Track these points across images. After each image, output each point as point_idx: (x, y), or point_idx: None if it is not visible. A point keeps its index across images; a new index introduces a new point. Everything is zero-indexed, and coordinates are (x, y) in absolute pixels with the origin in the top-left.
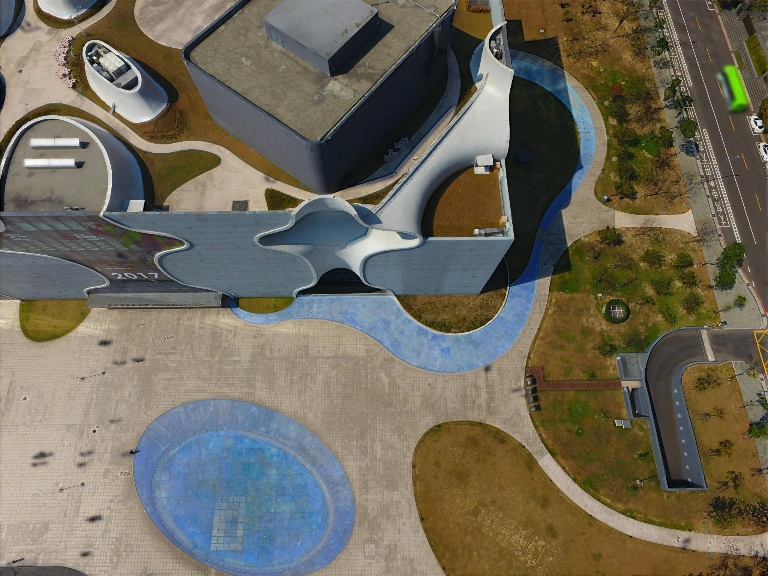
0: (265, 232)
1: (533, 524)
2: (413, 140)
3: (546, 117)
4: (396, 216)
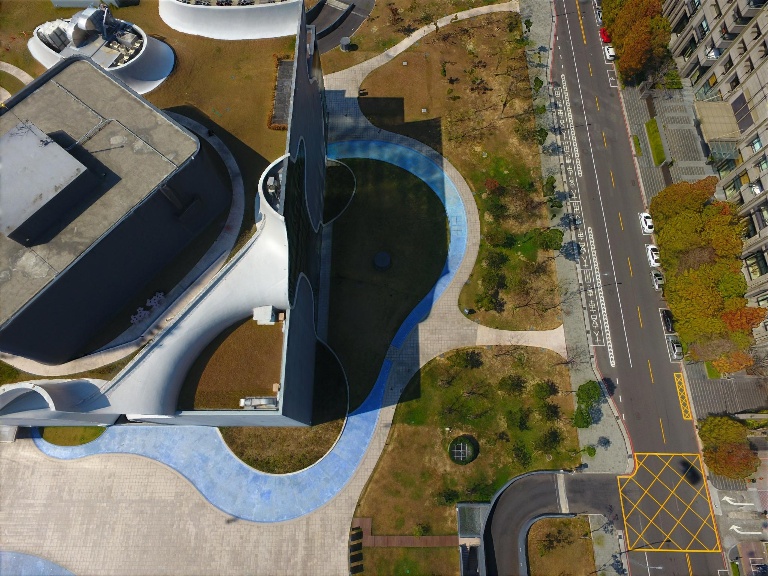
0: None
1: None
2: (171, 295)
3: (416, 212)
4: (131, 394)
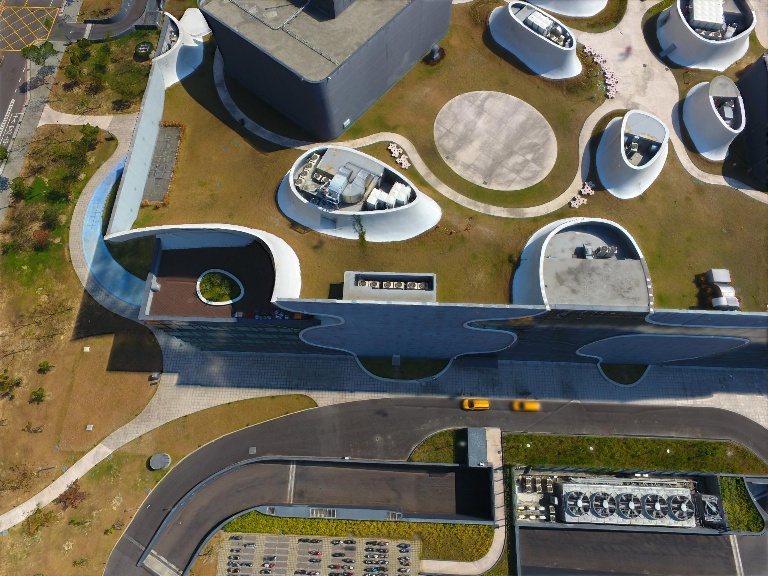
0: None
1: None
2: None
3: None
4: None
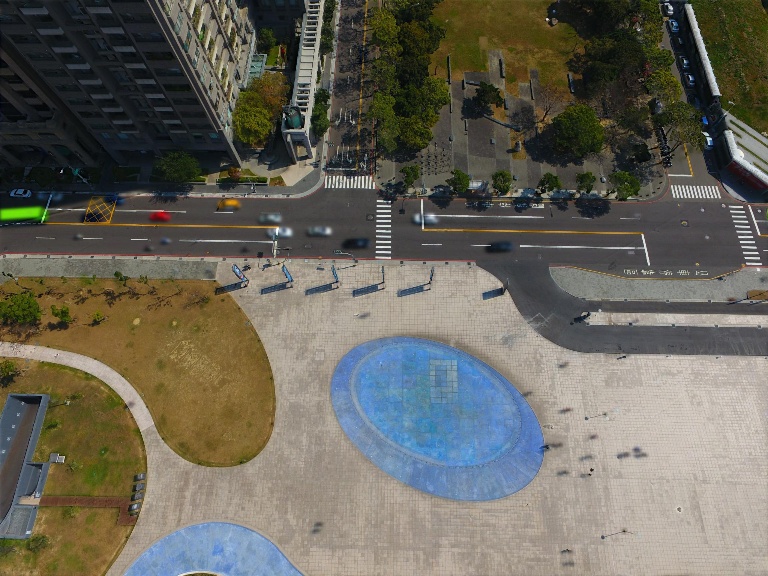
0: None
1: (175, 371)
2: None
3: None
4: None
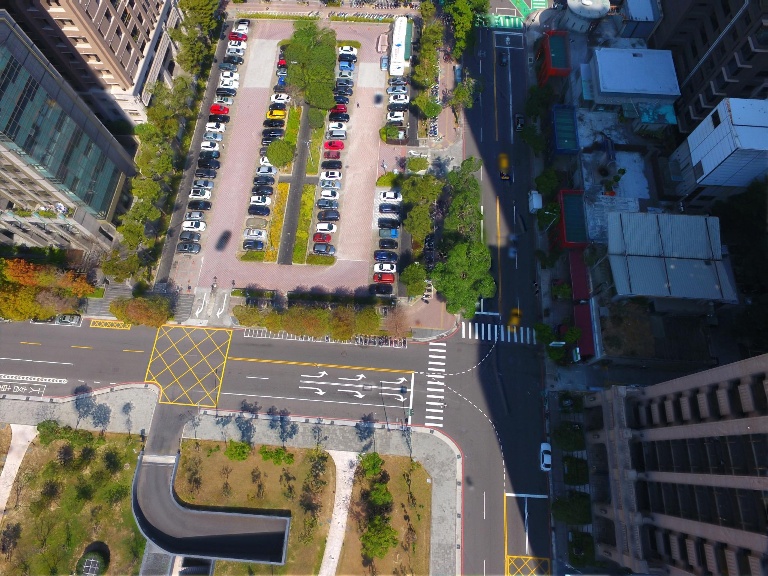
0: None
1: None
2: None
3: None
4: None
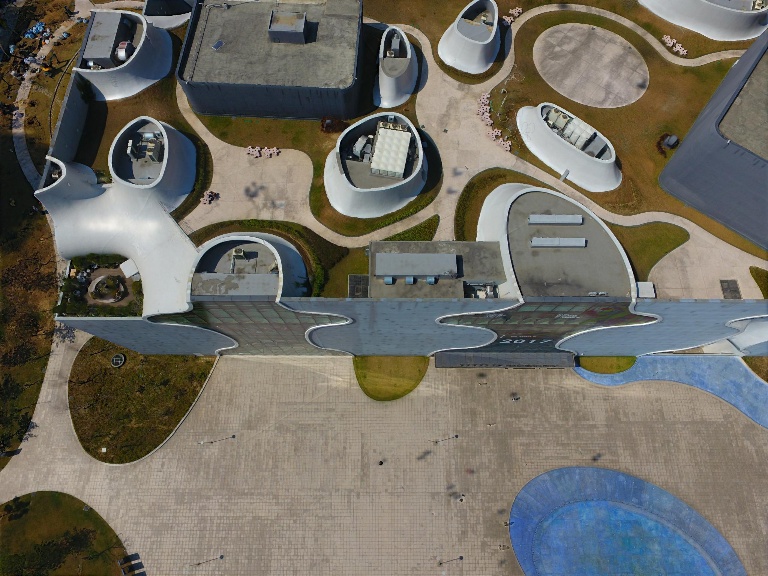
0: (763, 315)
1: None
2: None
3: None
4: None
